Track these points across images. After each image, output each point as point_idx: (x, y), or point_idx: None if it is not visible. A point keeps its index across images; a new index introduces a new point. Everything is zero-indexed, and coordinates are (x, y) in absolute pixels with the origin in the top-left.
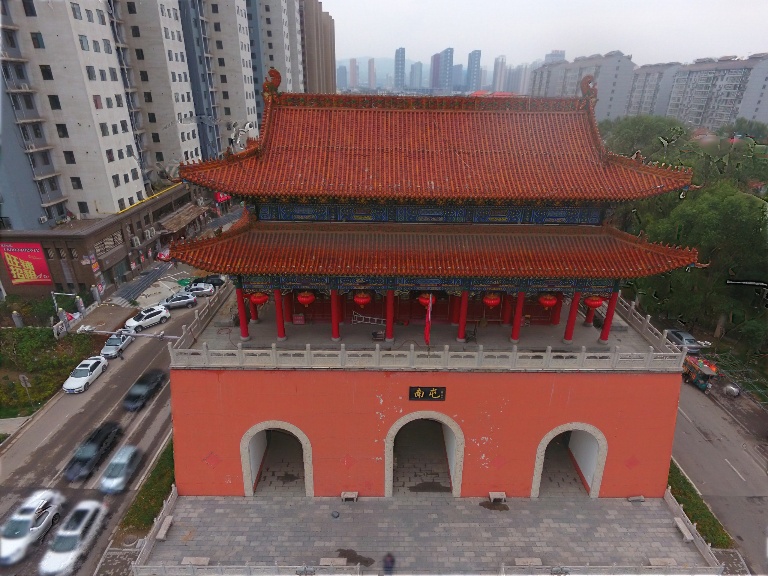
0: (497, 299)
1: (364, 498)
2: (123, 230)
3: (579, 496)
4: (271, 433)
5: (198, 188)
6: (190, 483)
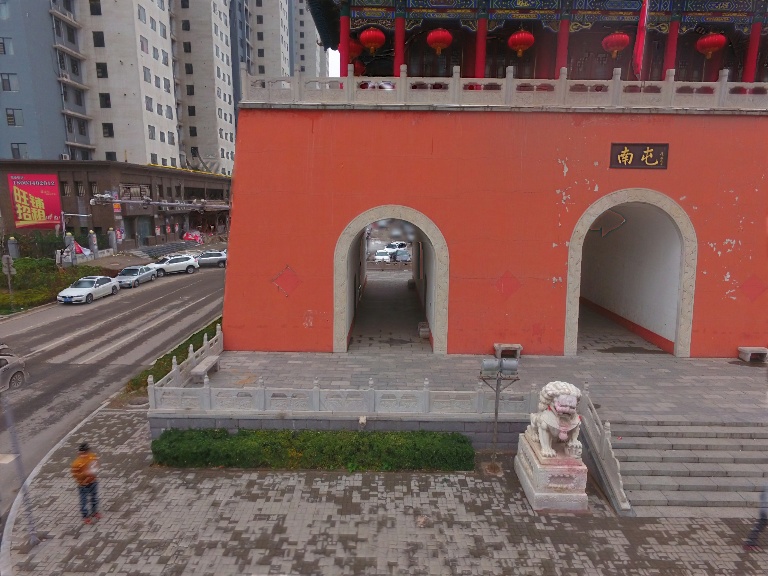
0: (722, 35)
1: (531, 356)
2: (152, 186)
3: None
4: (356, 310)
5: None
6: (246, 326)
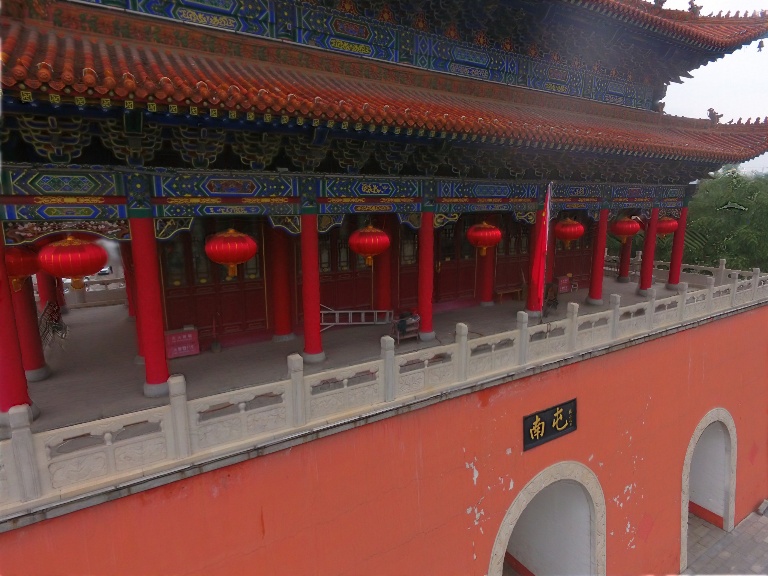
0: None
1: None
2: None
3: (718, 537)
4: None
5: None
6: None
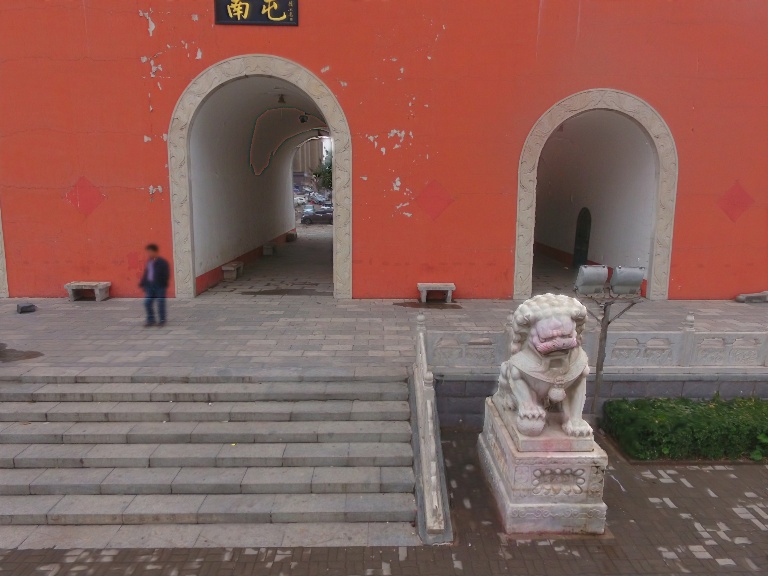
0: None
1: (125, 298)
2: None
3: None
4: None
5: None
6: None
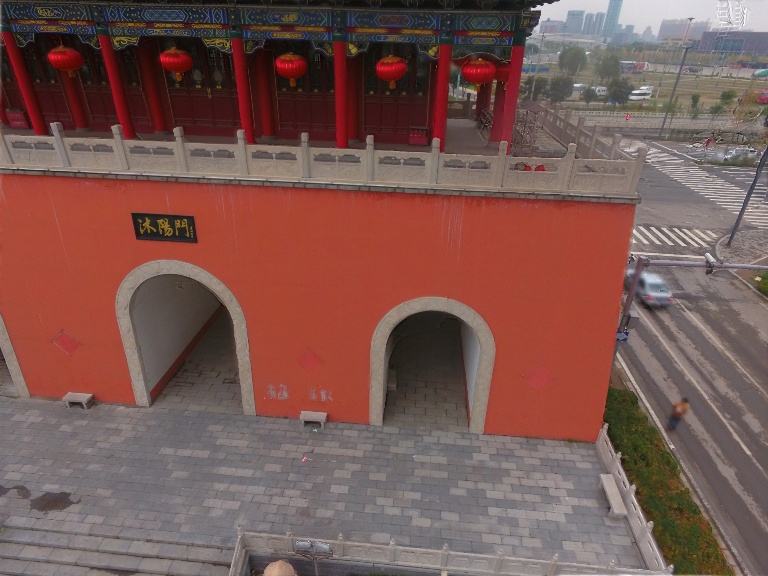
0: None
1: None
2: None
3: None
4: None
5: None
6: None
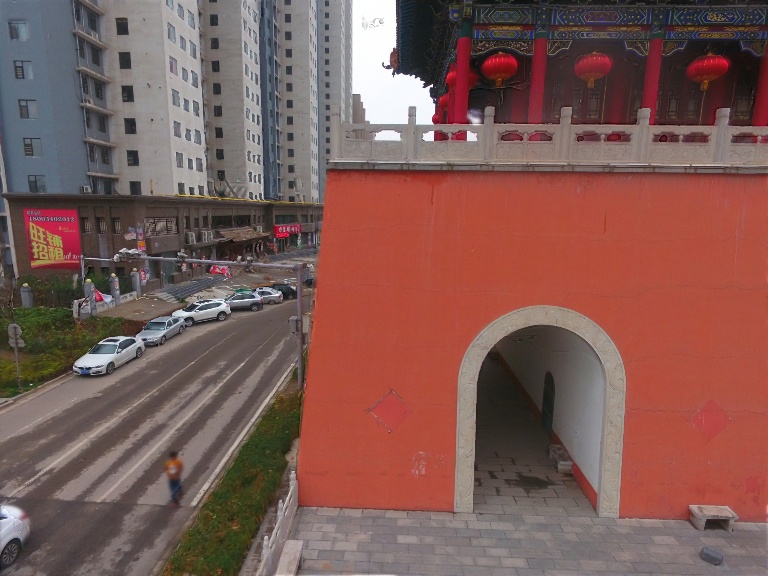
0: None
1: (744, 524)
2: (179, 218)
3: None
4: None
5: (258, 216)
6: (330, 473)
